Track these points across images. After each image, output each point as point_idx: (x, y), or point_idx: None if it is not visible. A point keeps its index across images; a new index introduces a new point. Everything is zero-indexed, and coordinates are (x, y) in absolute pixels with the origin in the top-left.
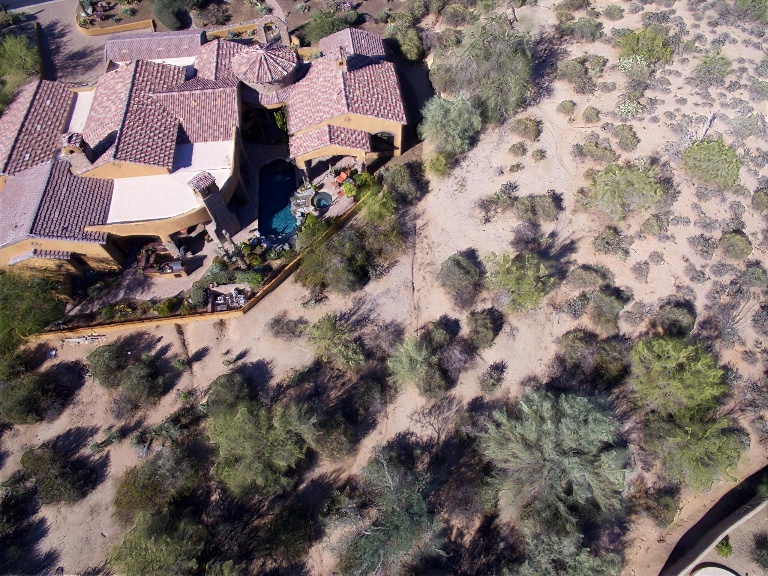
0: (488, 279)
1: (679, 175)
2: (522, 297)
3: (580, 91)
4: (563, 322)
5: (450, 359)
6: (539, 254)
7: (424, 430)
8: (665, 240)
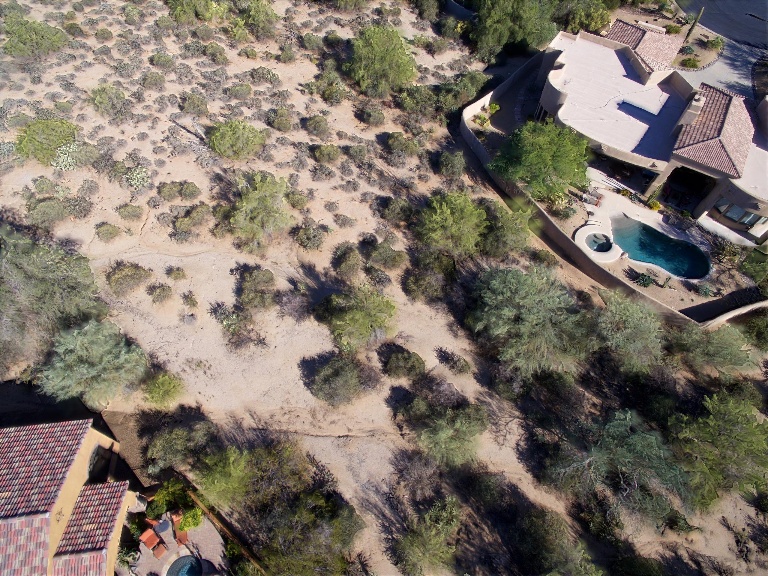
0: (346, 350)
1: (240, 166)
2: (388, 315)
3: (86, 213)
4: (393, 293)
5: (448, 397)
6: (315, 298)
7: (514, 432)
8: (314, 196)
